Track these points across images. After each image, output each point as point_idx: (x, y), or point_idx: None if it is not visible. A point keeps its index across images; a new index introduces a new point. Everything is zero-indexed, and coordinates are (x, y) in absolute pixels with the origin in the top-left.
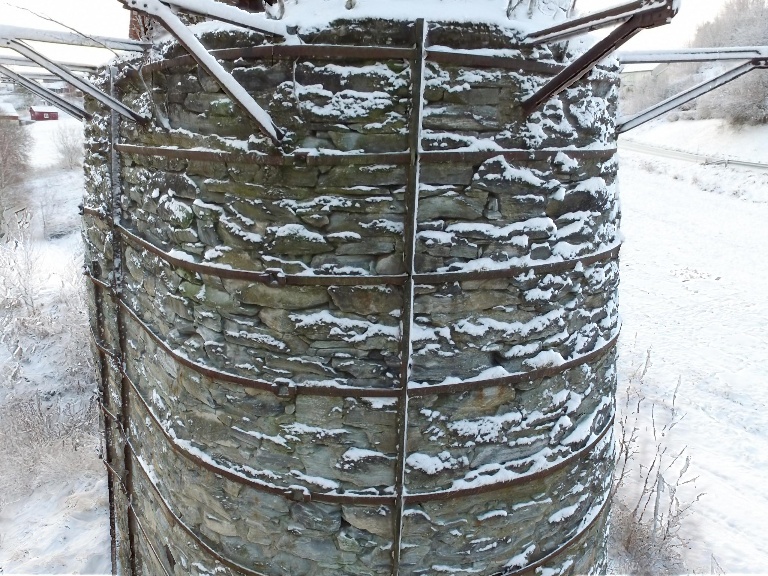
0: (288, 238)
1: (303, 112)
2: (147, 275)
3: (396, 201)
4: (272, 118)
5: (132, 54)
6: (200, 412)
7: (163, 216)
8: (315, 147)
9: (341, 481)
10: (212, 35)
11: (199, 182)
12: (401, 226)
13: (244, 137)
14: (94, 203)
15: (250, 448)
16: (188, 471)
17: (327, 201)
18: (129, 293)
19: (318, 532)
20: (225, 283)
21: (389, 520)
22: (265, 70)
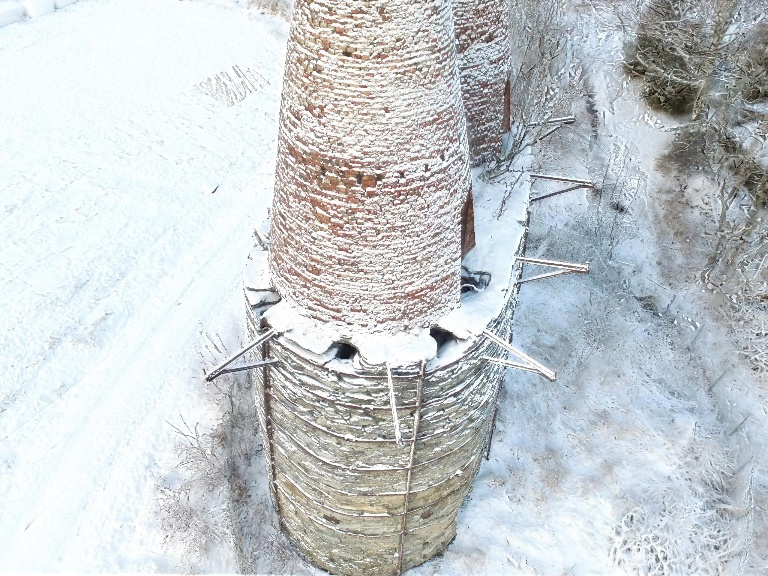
0: None
1: None
2: None
3: None
4: None
5: None
6: None
7: None
8: None
9: None
10: None
11: None
12: None
13: None
14: None
15: None
16: None
17: None
18: None
19: None
20: None
21: None
22: None
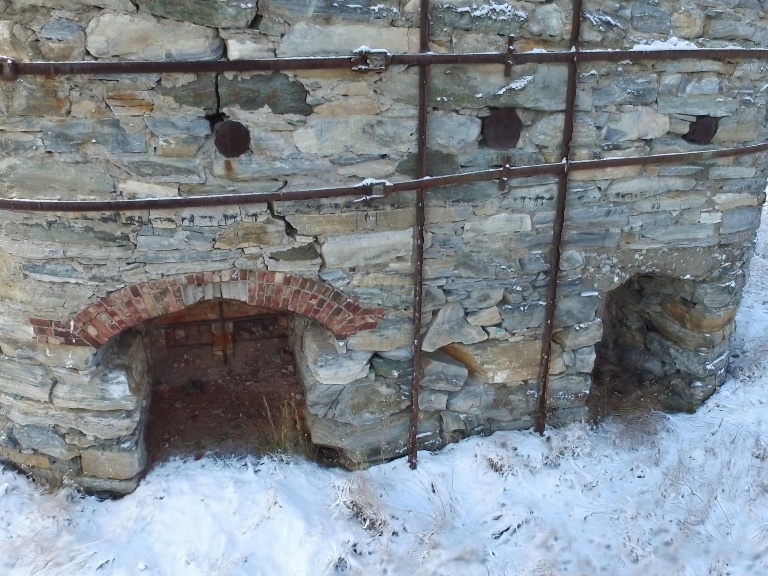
0: None
1: None
2: None
3: None
4: None
5: None
6: None
7: None
8: None
9: None
10: None
11: None
12: None
13: None
14: None
15: None
16: None
17: None
18: None
19: None
20: None
21: None
22: None
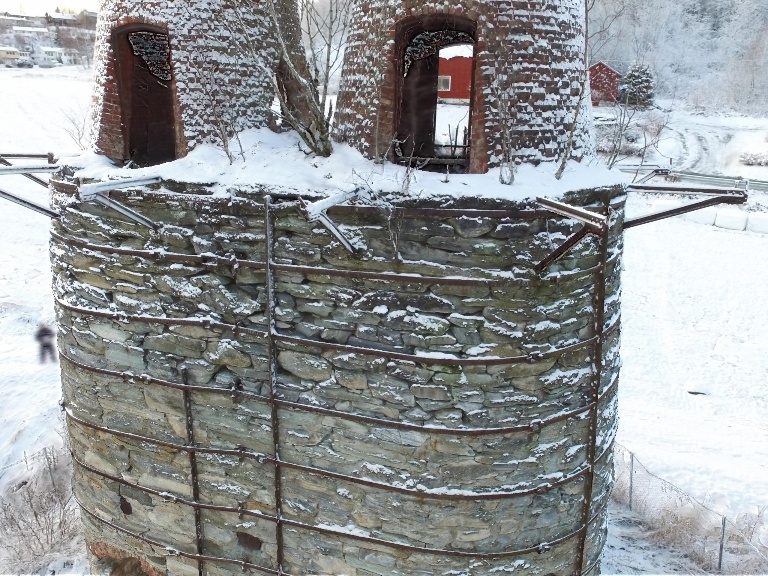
0: (544, 331)
1: None
2: (350, 374)
3: None
4: (532, 256)
5: (311, 190)
6: (457, 463)
7: (398, 327)
8: (558, 271)
9: (561, 470)
10: (475, 199)
11: (451, 300)
12: (592, 308)
13: (504, 268)
14: (173, 313)
15: None
16: (441, 509)
17: (563, 303)
18: (286, 391)
19: (550, 508)
20: (489, 368)
21: (584, 482)
22: (529, 226)
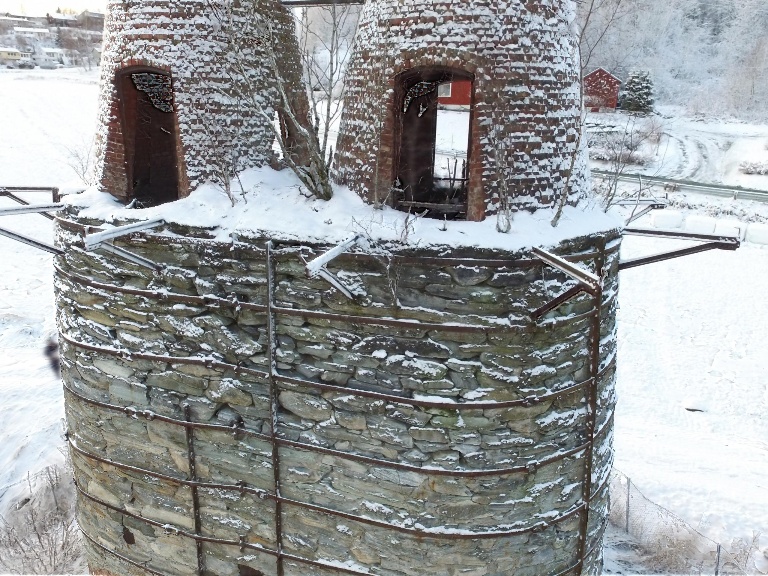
0: (540, 375)
1: (549, 298)
2: (350, 415)
3: (585, 337)
4: (528, 303)
5: (312, 237)
6: (455, 503)
7: (397, 371)
8: (553, 317)
9: (556, 509)
10: (472, 249)
11: (449, 346)
12: (587, 351)
13: (501, 315)
14: (176, 351)
15: (505, 512)
16: (438, 548)
17: (559, 347)
18: (286, 430)
19: (546, 545)
20: (486, 412)
21: (579, 519)
22: (525, 275)
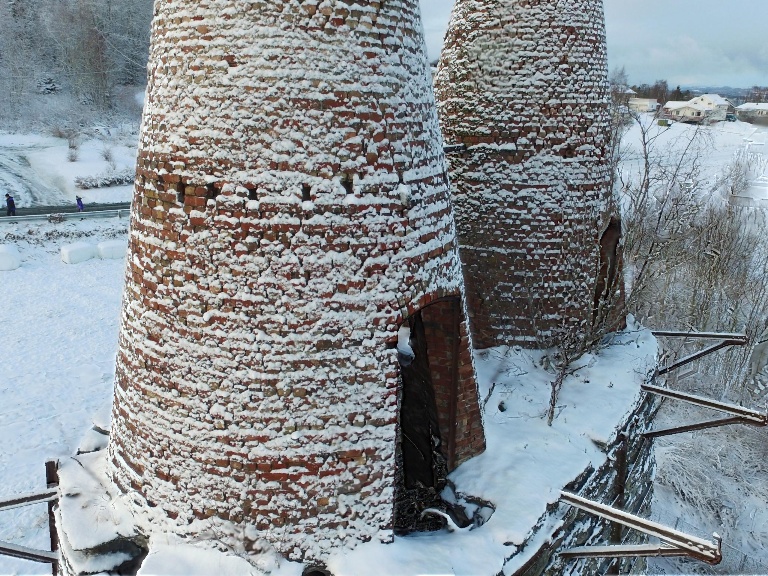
0: None
1: None
2: None
3: None
4: None
5: (633, 405)
6: None
7: None
8: None
9: None
10: None
11: None
12: None
13: None
14: None
15: None
16: None
17: None
18: None
19: None
20: None
21: None
22: None
